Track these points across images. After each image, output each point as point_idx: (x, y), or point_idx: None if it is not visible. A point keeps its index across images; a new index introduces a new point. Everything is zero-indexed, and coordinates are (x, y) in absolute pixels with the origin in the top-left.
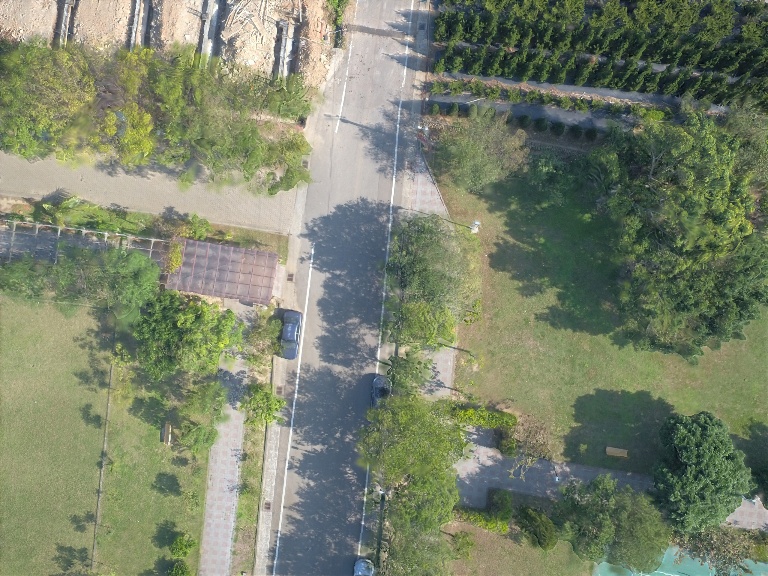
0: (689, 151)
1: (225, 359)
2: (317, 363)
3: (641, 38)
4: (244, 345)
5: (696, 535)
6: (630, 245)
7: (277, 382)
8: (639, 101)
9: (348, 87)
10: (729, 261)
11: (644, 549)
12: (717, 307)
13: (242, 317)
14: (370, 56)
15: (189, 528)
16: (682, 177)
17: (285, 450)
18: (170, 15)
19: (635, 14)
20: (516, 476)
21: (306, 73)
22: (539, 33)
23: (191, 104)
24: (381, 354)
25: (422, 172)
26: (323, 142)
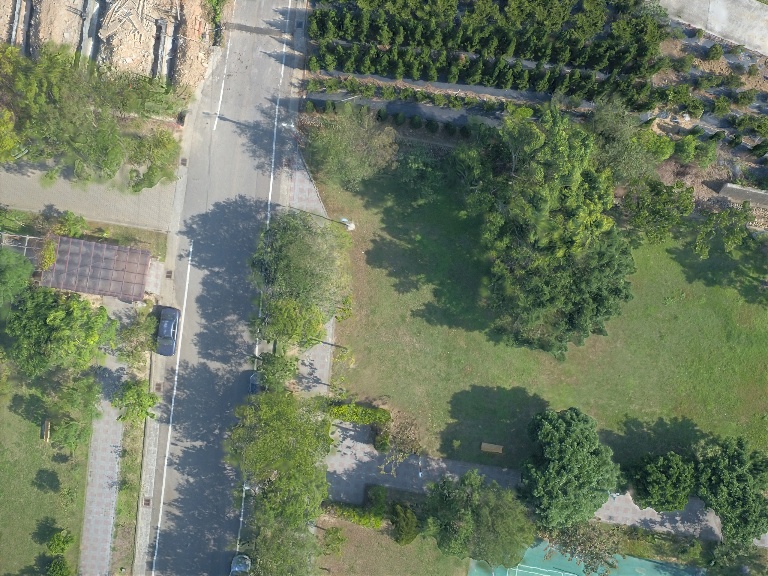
0: (540, 148)
1: (104, 356)
2: (196, 360)
3: (509, 36)
4: (117, 342)
5: (565, 530)
6: (490, 241)
7: (156, 379)
8: (513, 98)
9: (226, 85)
10: (584, 257)
11: (501, 544)
12: (574, 303)
13: (121, 314)
14: (248, 54)
15: (69, 524)
16: (533, 173)
17: (164, 446)
18: (48, 13)
19: (506, 12)
20: None
21: (183, 71)
22: (410, 31)
23: (49, 102)
24: (259, 351)
25: (299, 169)
26: (201, 140)
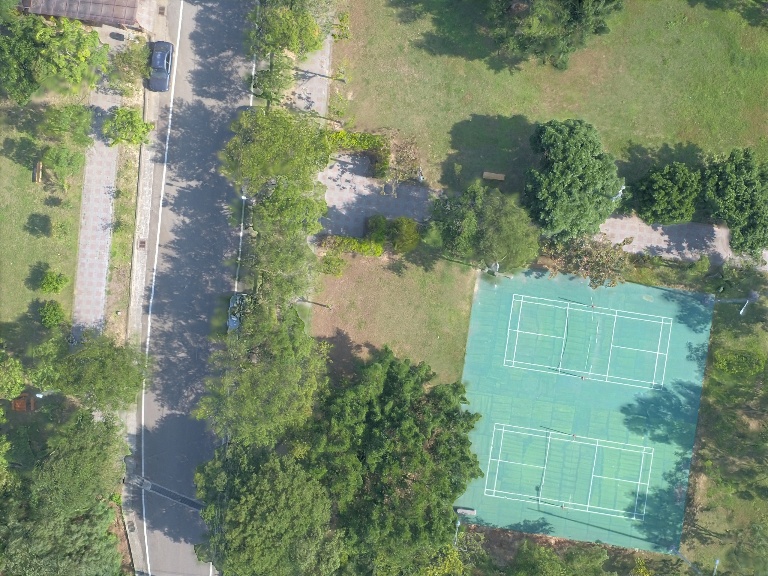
0: None
1: (97, 95)
2: (190, 97)
3: None
4: (109, 67)
5: (570, 245)
6: None
7: (150, 117)
8: None
9: None
10: None
11: (506, 234)
12: None
13: (113, 52)
14: None
15: (63, 269)
16: None
17: (159, 187)
18: None
19: None
20: (393, 205)
21: None
22: None
23: None
24: None
25: None
26: None
